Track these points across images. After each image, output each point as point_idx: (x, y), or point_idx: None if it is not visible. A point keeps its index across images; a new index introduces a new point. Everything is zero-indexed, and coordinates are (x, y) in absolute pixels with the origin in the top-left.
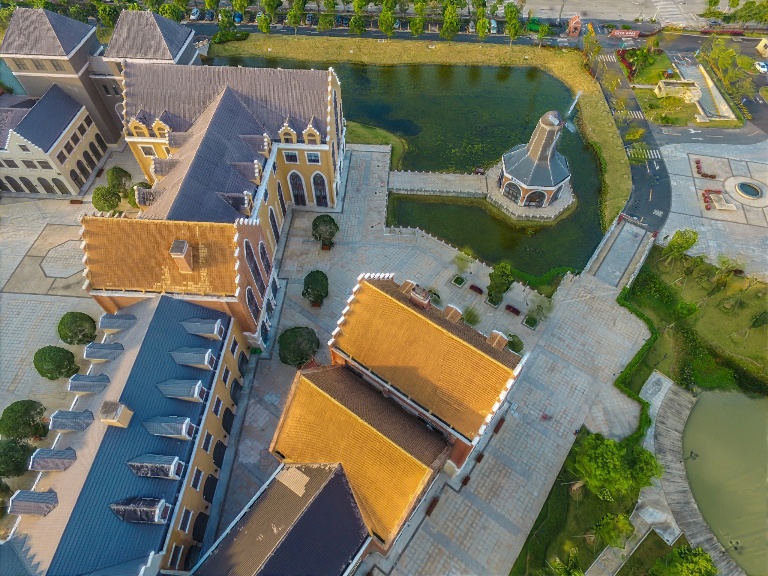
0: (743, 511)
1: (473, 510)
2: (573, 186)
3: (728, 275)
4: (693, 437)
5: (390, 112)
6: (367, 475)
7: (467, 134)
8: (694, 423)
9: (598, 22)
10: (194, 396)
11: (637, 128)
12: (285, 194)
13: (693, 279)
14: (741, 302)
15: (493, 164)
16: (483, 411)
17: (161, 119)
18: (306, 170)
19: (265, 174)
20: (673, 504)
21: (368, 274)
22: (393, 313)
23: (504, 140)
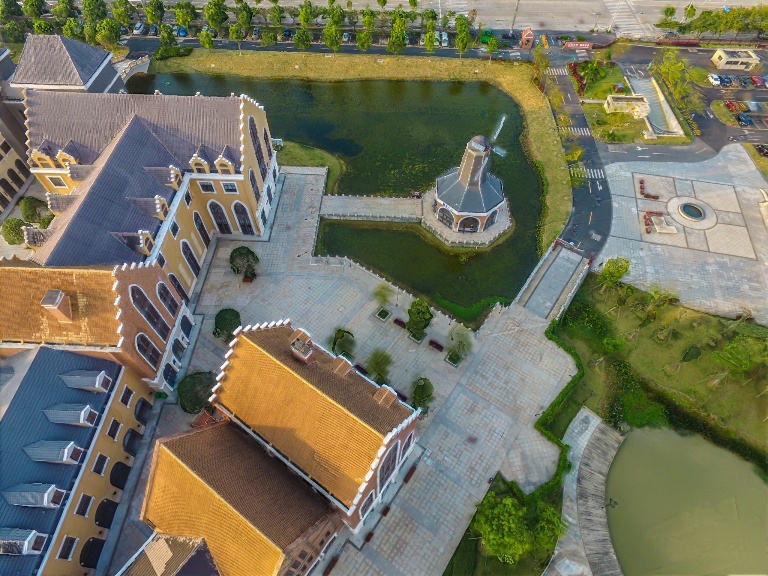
0: (664, 561)
1: (374, 570)
2: (512, 209)
3: (663, 304)
4: (618, 480)
5: (331, 131)
6: (229, 553)
7: (409, 154)
8: (620, 464)
9: (553, 33)
10: (63, 460)
11: (583, 146)
12: (207, 223)
13: (628, 308)
14: (675, 333)
15: (432, 186)
16: (359, 479)
17: (65, 150)
18: (225, 199)
19: (172, 208)
20: (591, 555)
21: (248, 326)
22: (270, 370)
23: (446, 160)
